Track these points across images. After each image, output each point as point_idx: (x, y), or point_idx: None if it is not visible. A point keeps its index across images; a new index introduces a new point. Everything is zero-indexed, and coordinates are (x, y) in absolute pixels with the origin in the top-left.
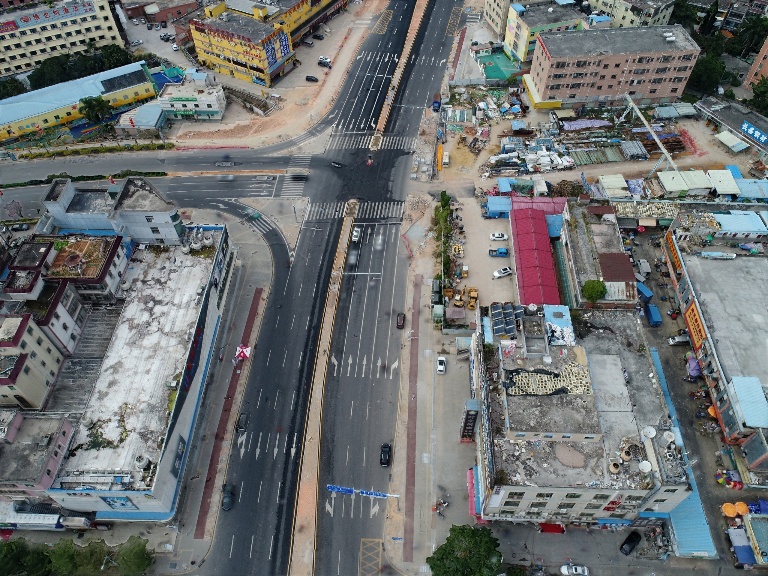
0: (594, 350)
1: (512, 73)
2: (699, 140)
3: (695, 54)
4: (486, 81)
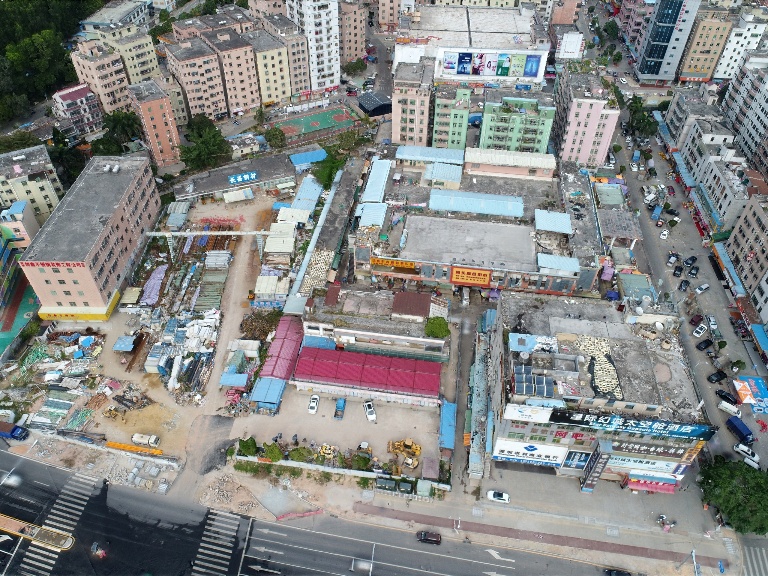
0: (546, 331)
1: (0, 330)
2: (222, 215)
3: (147, 164)
4: (1, 361)
